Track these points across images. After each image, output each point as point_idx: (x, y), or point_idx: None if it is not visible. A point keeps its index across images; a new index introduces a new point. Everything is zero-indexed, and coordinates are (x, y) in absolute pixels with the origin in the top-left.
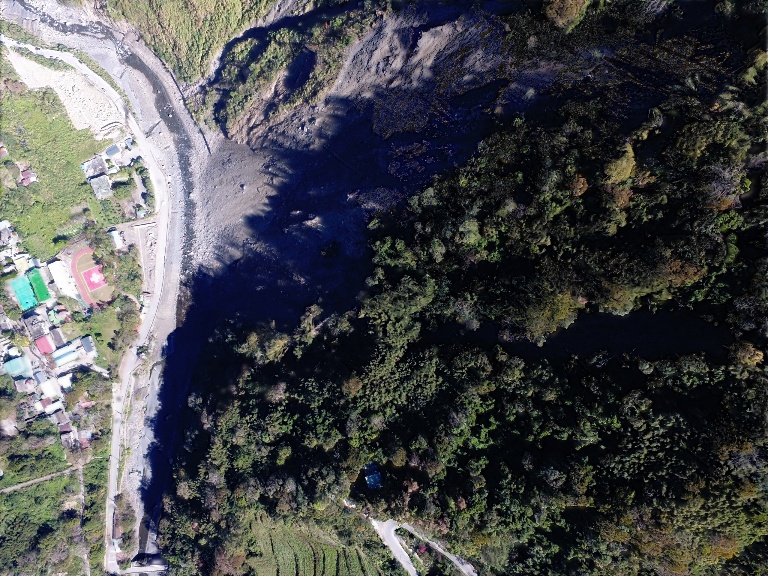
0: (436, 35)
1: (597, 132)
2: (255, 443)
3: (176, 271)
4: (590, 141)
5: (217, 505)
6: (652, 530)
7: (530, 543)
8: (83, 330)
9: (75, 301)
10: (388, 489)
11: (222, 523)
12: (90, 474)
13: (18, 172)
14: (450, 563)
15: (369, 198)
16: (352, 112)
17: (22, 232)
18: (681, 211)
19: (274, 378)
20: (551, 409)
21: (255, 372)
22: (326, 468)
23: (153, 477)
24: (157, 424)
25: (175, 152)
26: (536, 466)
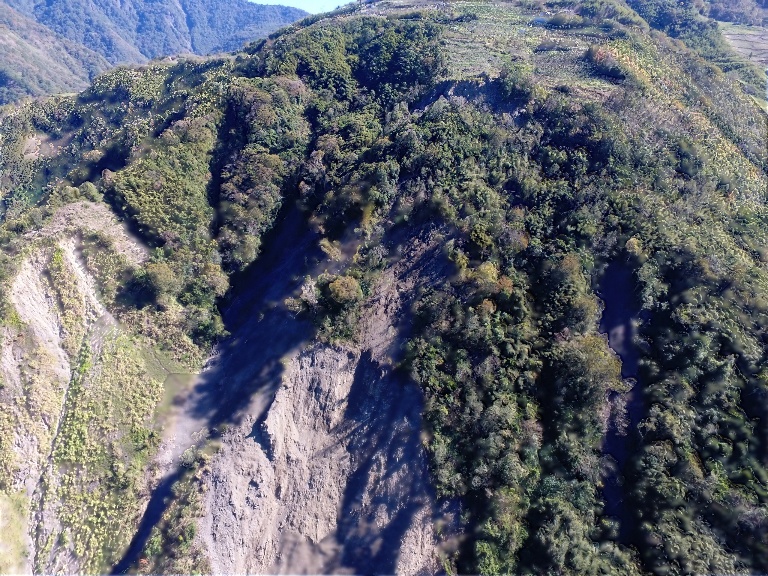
0: (277, 410)
1: None
2: None
3: None
4: (453, 296)
5: None
6: None
7: None
8: None
9: None
10: None
11: None
12: None
13: None
14: None
15: (407, 573)
16: None
17: None
18: (524, 261)
19: None
20: (707, 392)
21: None
22: None
23: None
24: None
25: None
26: None
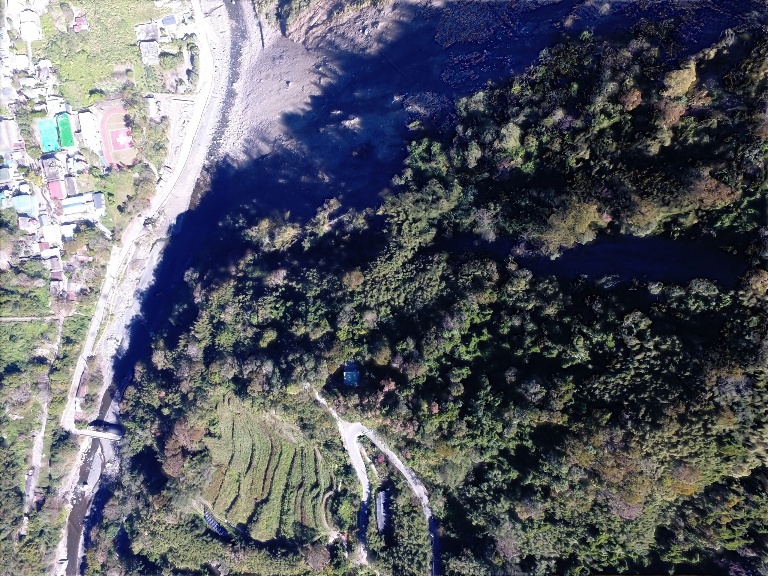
0: None
1: (663, 54)
2: (242, 323)
3: (202, 154)
4: (654, 59)
5: (189, 377)
6: (619, 454)
7: (490, 466)
8: (97, 186)
9: (96, 156)
10: (364, 387)
11: (190, 395)
12: (69, 327)
13: (72, 17)
14: (404, 479)
15: (415, 101)
16: (418, 19)
17: (61, 76)
18: (728, 138)
19: (276, 267)
20: (548, 324)
21: (258, 258)
22: (308, 355)
23: (129, 349)
24: (146, 298)
25: (229, 39)
26: (518, 380)
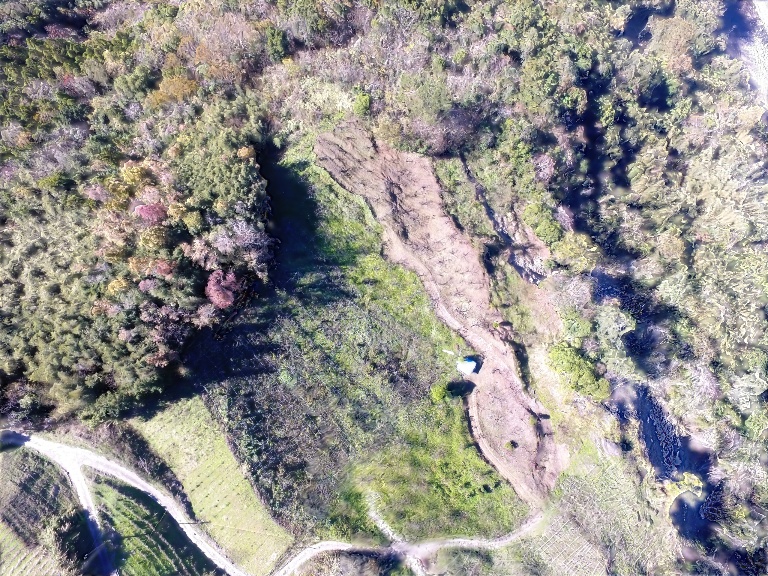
0: None
1: None
2: None
3: None
4: None
5: None
6: None
7: None
8: None
9: None
10: None
11: None
12: None
13: None
14: None
15: None
16: None
17: None
18: None
19: None
20: None
21: None
22: None
23: None
24: None
25: None
26: None
